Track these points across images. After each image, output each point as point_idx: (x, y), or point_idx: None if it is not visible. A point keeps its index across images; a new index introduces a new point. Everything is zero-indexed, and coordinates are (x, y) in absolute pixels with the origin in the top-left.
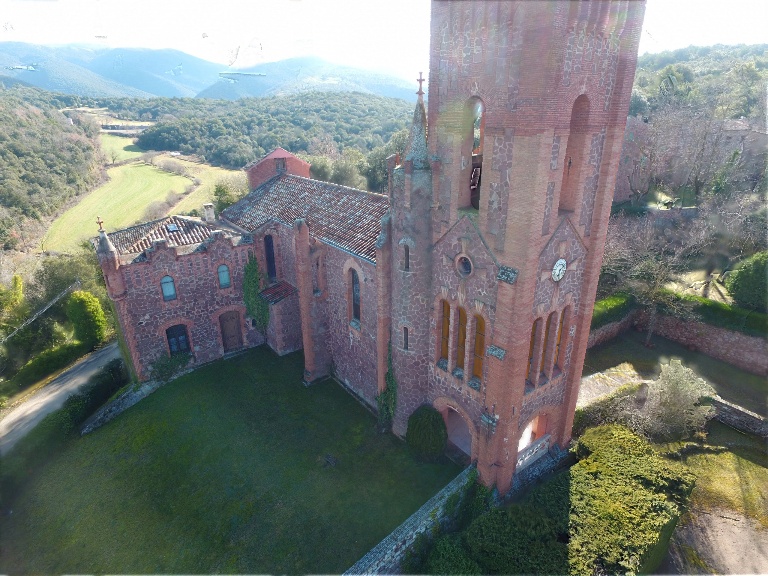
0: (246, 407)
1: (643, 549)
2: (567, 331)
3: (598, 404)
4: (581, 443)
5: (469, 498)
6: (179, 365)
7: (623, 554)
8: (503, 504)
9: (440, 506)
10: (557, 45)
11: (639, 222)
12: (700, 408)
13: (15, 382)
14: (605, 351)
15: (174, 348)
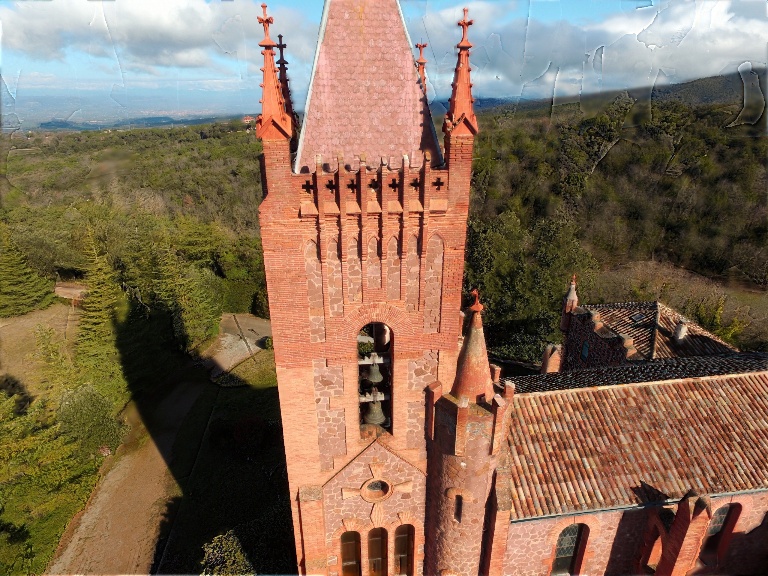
0: None
1: None
2: None
3: None
4: None
5: None
6: None
7: None
8: None
9: None
10: None
11: None
12: None
13: None
14: None
15: None
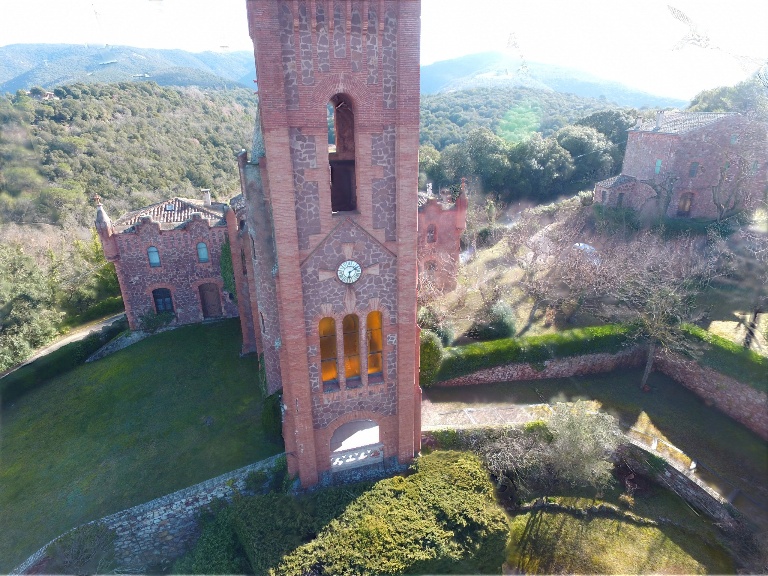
0: (186, 364)
1: (370, 573)
2: (383, 338)
3: (479, 430)
4: (416, 461)
5: (279, 481)
6: (164, 322)
7: (346, 570)
8: (302, 495)
9: (240, 479)
10: (268, 46)
11: (674, 241)
12: (598, 462)
13: (81, 317)
14: (580, 384)
15: (161, 307)
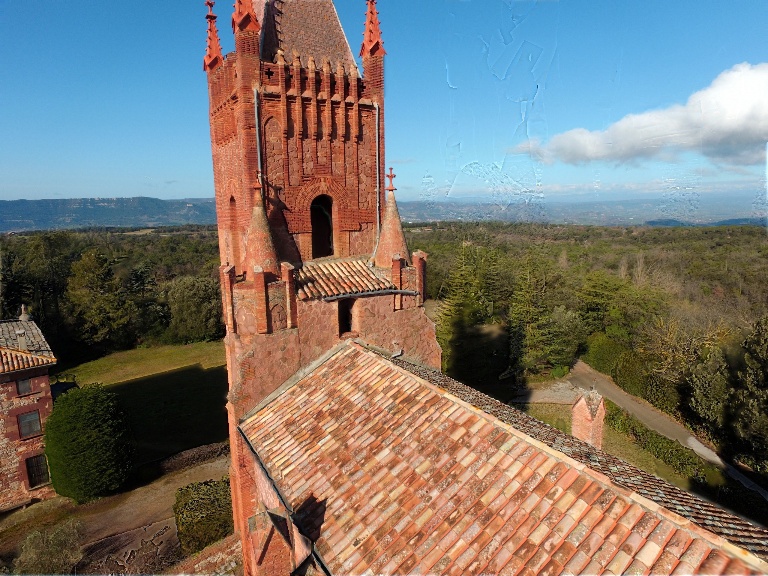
0: None
1: None
2: None
3: (159, 567)
4: None
5: None
6: None
7: None
8: None
9: None
10: None
11: None
12: None
13: None
14: None
15: None
